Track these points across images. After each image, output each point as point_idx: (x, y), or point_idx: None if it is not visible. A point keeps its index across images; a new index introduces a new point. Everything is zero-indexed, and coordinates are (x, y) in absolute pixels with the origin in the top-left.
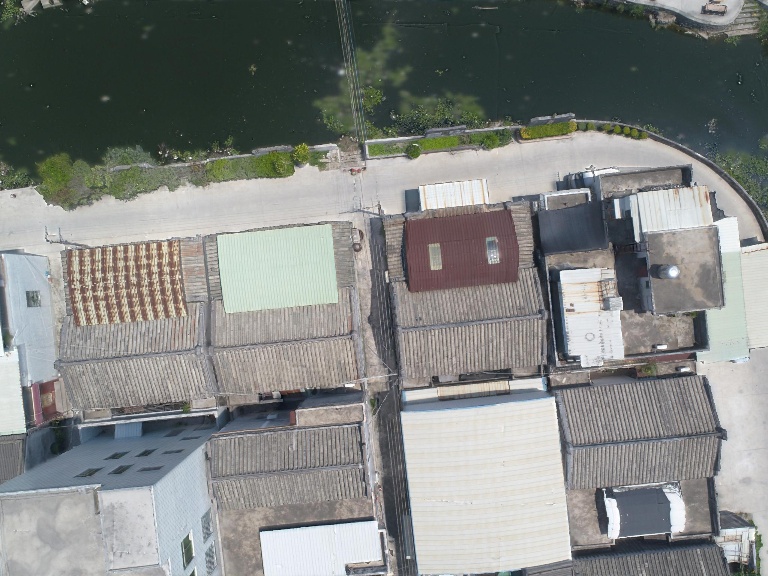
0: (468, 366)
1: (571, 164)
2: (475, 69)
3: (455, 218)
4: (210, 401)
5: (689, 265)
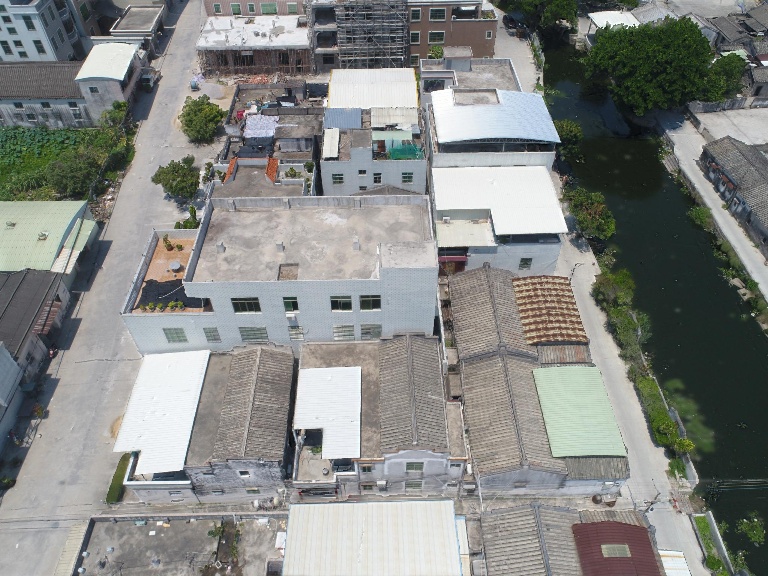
0: None
1: None
2: None
3: None
4: (453, 361)
5: None
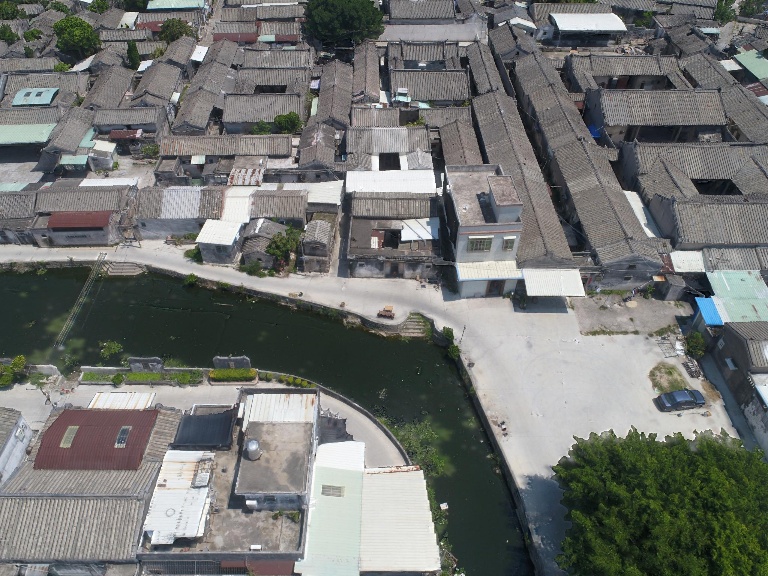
0: (53, 550)
1: None
2: (201, 338)
3: (107, 412)
4: None
5: (281, 452)
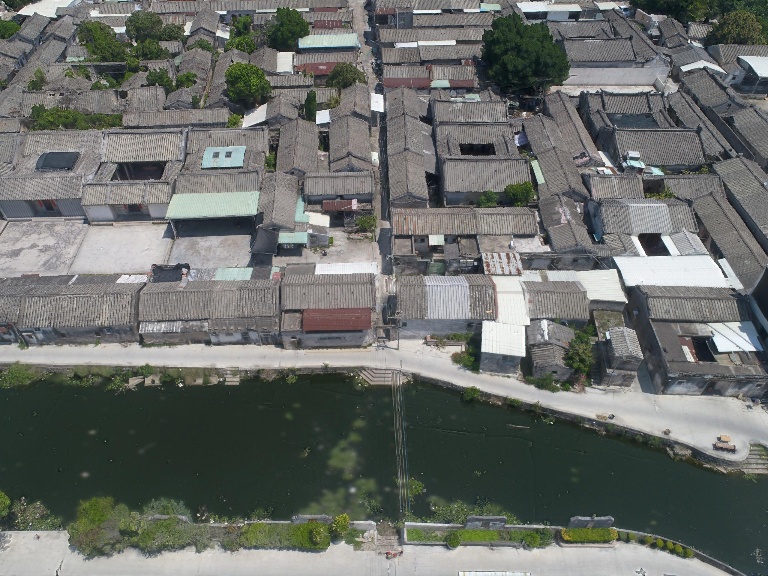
0: None
1: (618, 575)
2: (511, 474)
3: None
4: None
5: None
